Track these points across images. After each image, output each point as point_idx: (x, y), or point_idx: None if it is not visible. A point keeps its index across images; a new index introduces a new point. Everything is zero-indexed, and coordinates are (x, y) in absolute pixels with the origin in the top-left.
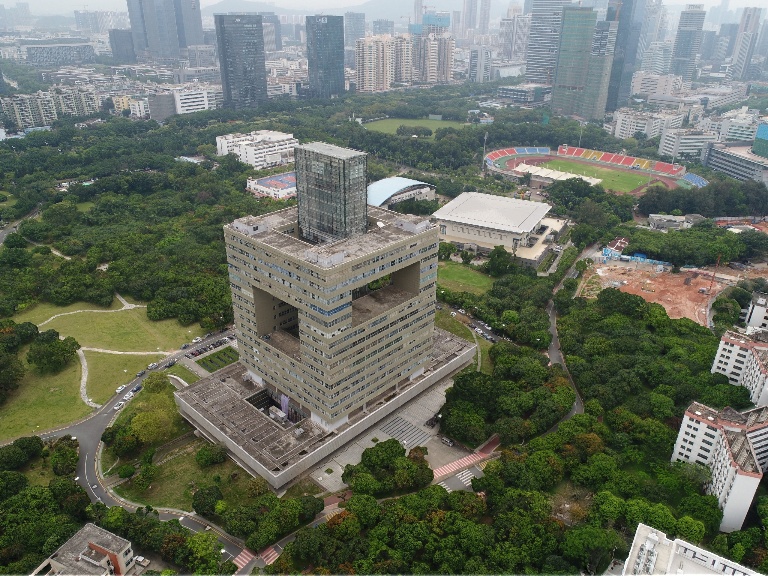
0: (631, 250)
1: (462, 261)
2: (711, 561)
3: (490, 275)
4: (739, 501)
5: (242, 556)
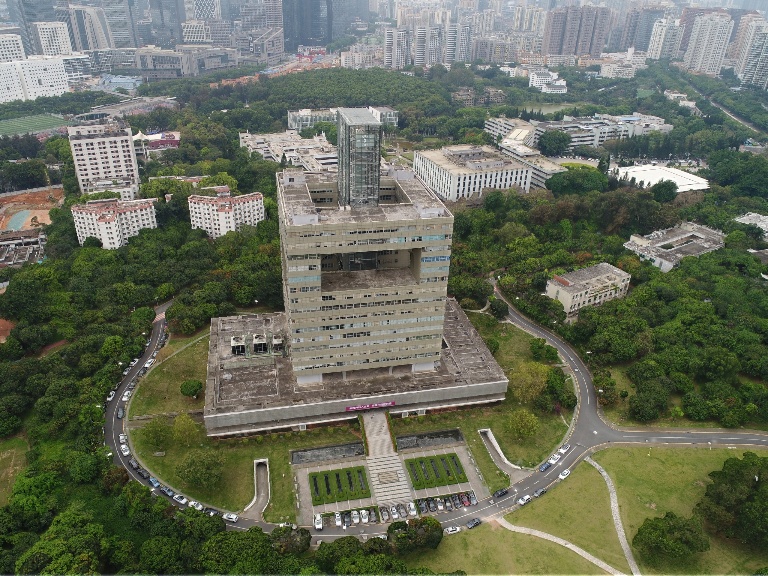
0: None
1: None
2: None
3: None
4: None
5: None
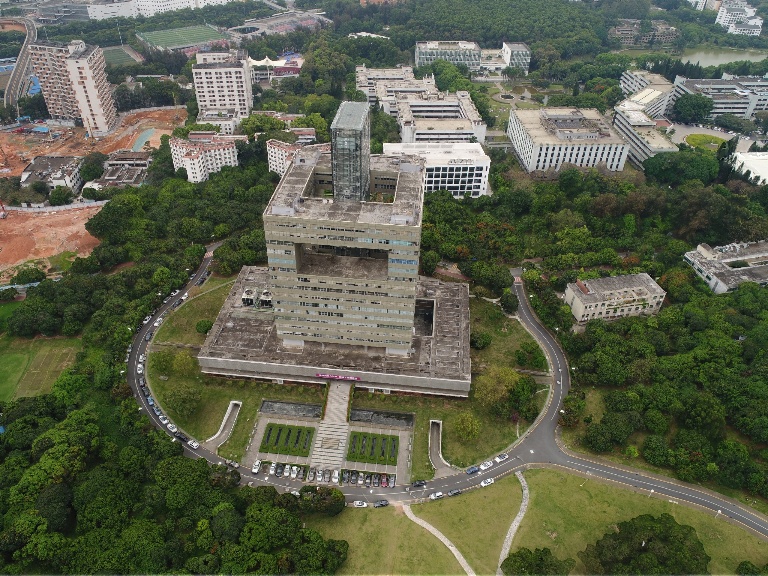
0: None
1: None
2: None
3: None
4: None
5: None
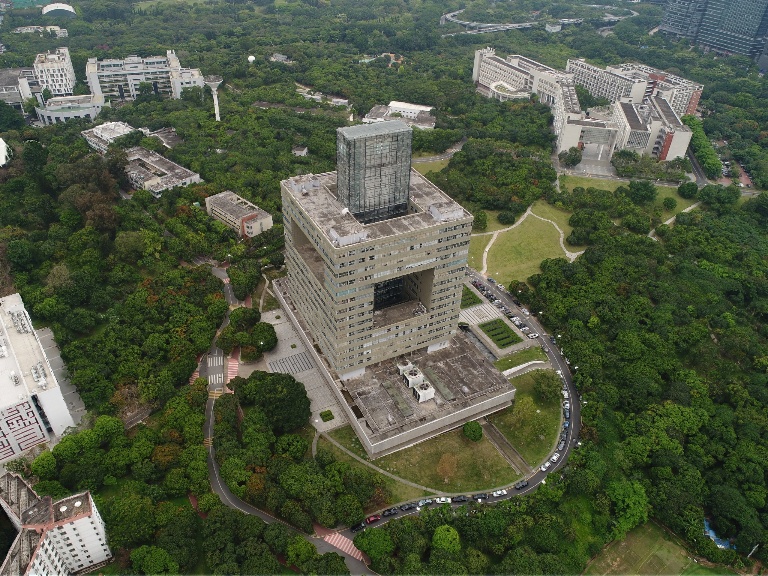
0: None
1: None
2: None
3: None
4: None
5: None
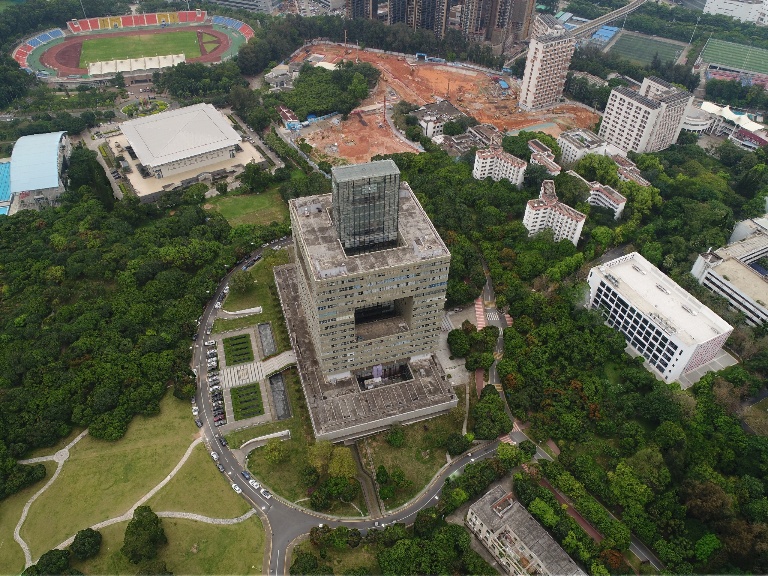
0: (305, 116)
1: (217, 194)
2: (616, 262)
3: (258, 192)
4: (578, 233)
5: (505, 441)
